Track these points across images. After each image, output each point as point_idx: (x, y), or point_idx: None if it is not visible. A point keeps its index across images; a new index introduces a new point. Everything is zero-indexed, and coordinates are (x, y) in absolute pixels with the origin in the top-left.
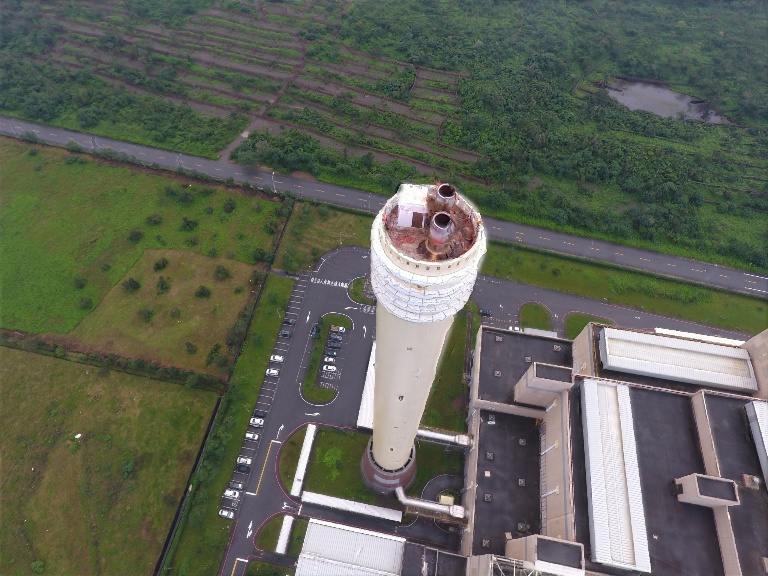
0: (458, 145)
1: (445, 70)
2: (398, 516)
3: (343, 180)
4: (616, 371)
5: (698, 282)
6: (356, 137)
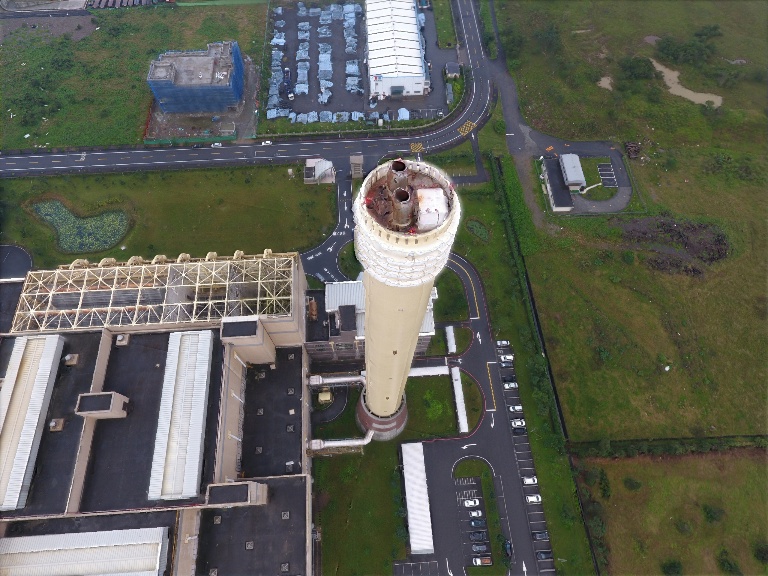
0: None
1: None
2: None
3: None
4: None
5: None
6: None
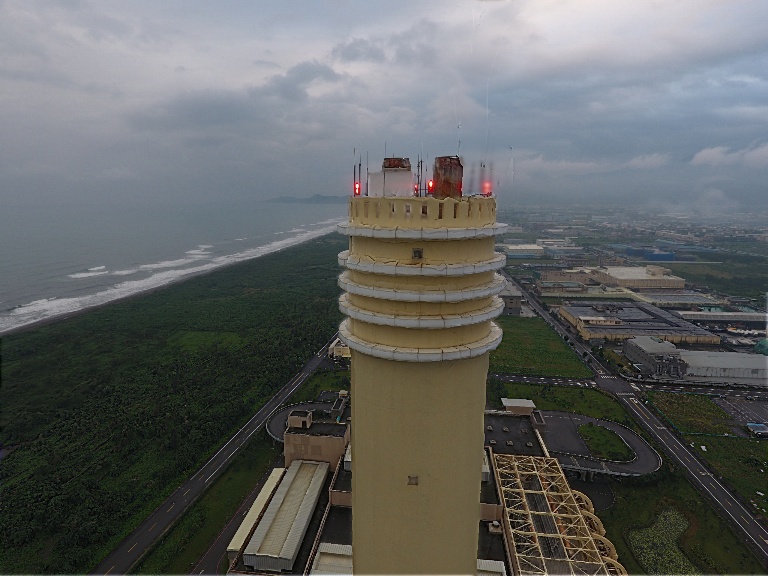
0: None
1: None
2: None
3: None
4: (296, 558)
5: (184, 511)
6: None
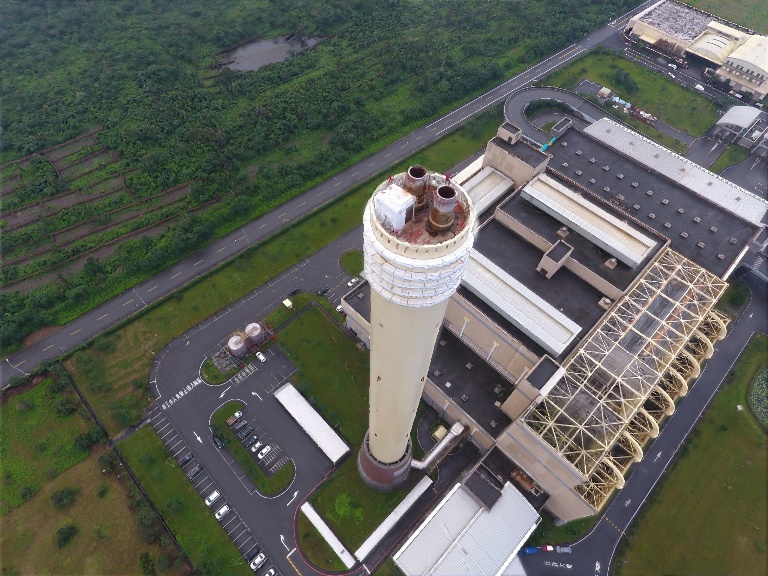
0: (160, 190)
1: (73, 138)
2: (427, 481)
3: (88, 303)
4: None
5: (412, 153)
6: (56, 257)
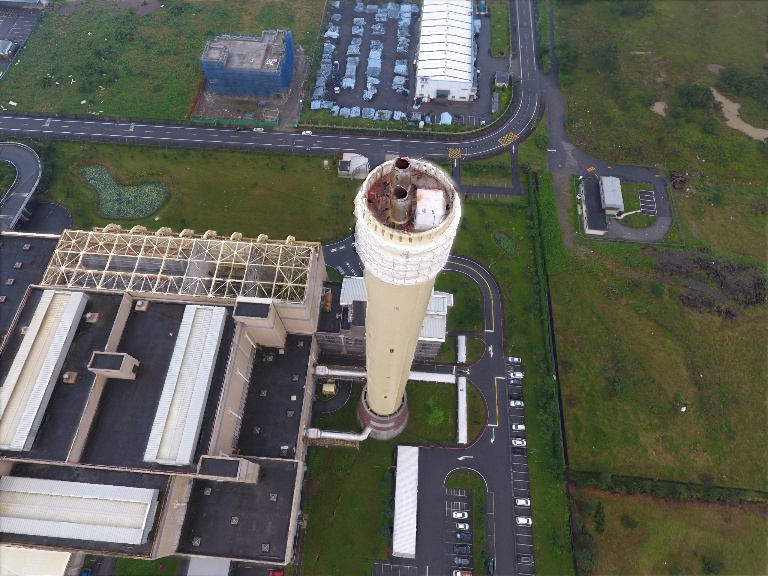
0: None
1: None
2: None
3: None
4: None
5: None
6: None
